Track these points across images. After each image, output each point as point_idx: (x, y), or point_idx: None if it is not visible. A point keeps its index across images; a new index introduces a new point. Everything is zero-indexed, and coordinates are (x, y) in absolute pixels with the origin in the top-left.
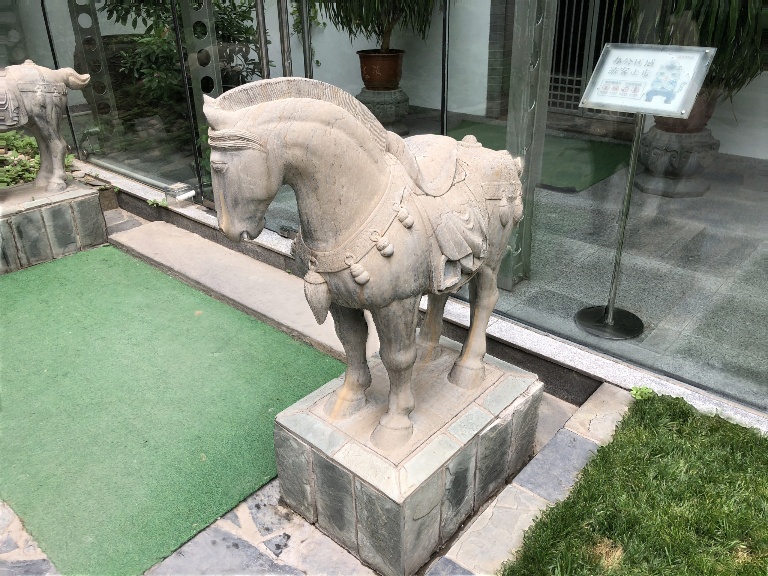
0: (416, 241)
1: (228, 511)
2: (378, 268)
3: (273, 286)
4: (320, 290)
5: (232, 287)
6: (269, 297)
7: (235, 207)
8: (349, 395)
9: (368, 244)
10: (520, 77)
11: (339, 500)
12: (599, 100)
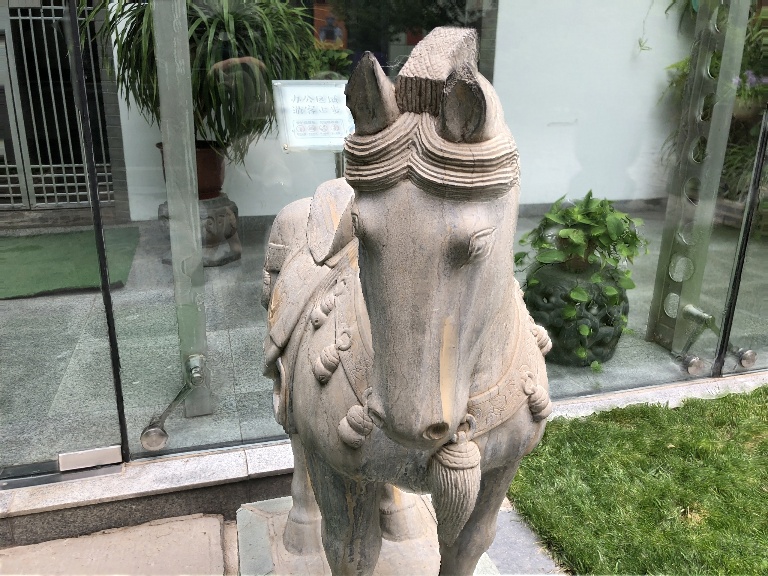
0: None
1: None
2: (546, 379)
3: None
4: None
5: None
6: None
7: (471, 349)
8: None
9: (534, 344)
10: (177, 128)
11: None
12: (302, 143)
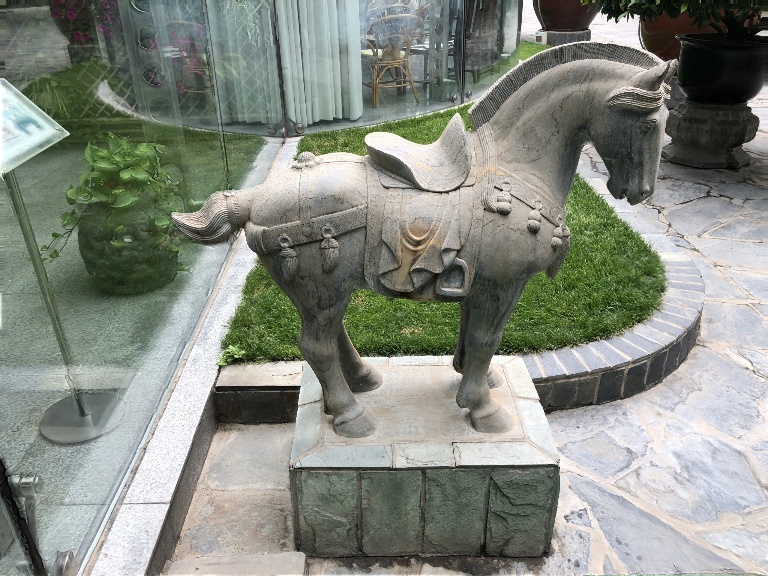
0: None
1: (612, 575)
2: None
3: None
4: None
5: None
6: None
7: None
8: None
9: None
10: None
11: None
12: None
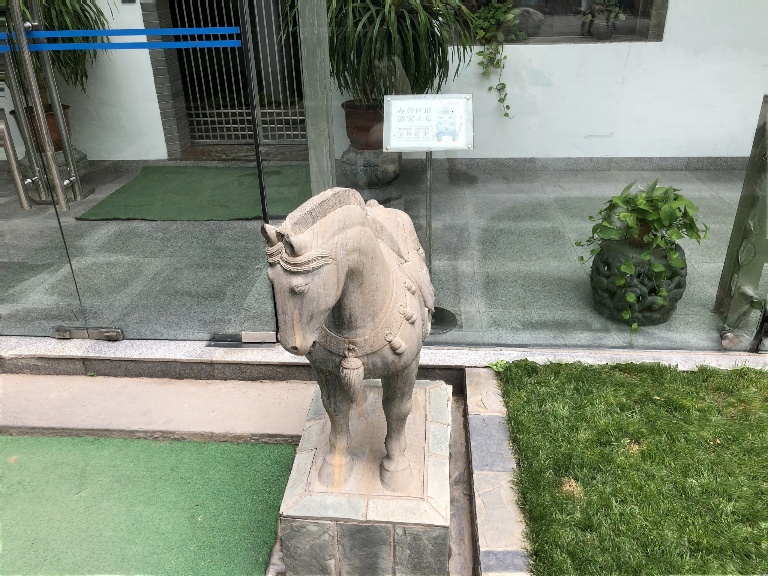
0: (418, 303)
1: None
2: (409, 335)
3: (87, 396)
4: (361, 372)
5: (38, 415)
6: (95, 409)
7: (309, 322)
8: (343, 460)
9: (399, 318)
10: (319, 133)
11: (373, 555)
12: (399, 145)
